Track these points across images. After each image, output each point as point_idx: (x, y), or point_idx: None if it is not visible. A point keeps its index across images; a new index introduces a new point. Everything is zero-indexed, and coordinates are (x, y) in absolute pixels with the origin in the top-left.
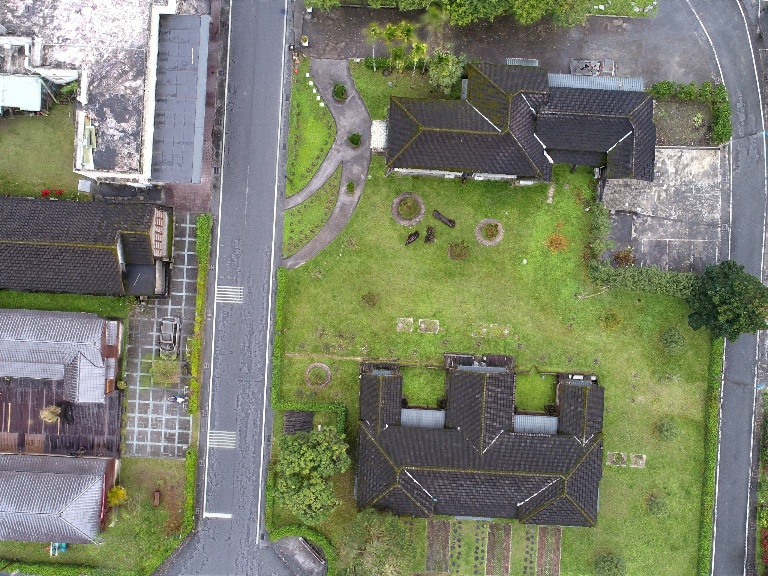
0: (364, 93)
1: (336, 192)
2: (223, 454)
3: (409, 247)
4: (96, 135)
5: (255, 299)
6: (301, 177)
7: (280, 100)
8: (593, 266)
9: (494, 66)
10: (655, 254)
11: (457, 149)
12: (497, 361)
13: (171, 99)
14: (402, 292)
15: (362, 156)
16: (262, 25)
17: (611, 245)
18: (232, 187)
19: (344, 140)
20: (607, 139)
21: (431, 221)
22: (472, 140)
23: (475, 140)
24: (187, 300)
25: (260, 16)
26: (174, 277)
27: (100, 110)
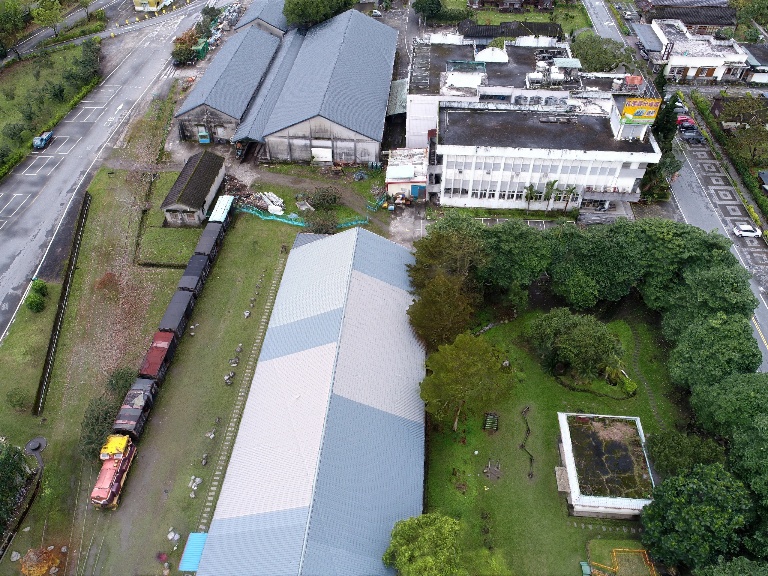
0: None
1: None
2: (597, 1)
3: None
4: None
5: None
6: None
7: None
8: None
9: None
10: None
11: None
12: (505, 9)
13: None
14: None
15: None
16: None
17: None
18: None
19: None
20: None
21: None
22: None
23: None
24: None
25: None
26: None
27: (679, 33)
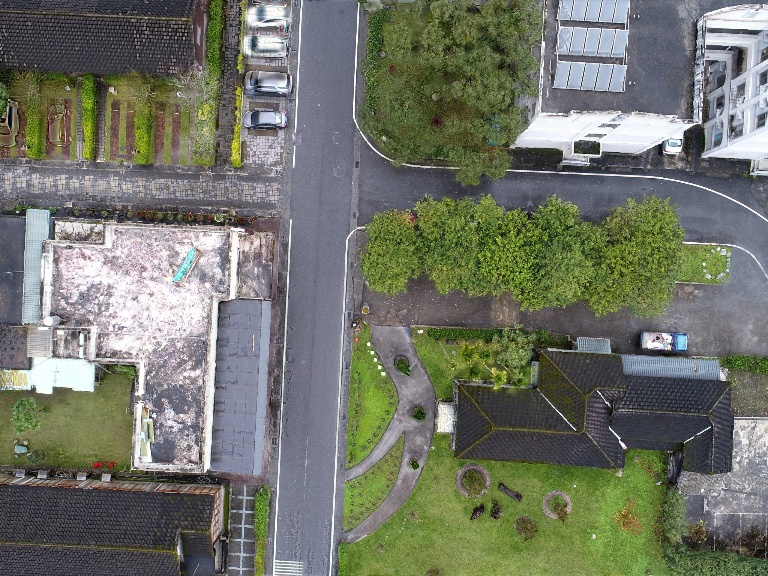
0: (427, 361)
1: (398, 463)
2: None
3: (474, 520)
4: (154, 426)
5: (315, 574)
6: (362, 448)
7: (340, 368)
8: (668, 555)
9: (567, 355)
10: (728, 528)
11: (530, 445)
12: None
13: (231, 387)
14: (467, 567)
15: (425, 426)
16: (321, 291)
17: (686, 532)
18: (290, 458)
19: (406, 410)
20: (684, 432)
21: (496, 494)
22: (546, 438)
23: (549, 438)
24: (244, 575)
25: (319, 282)
26: (231, 551)
27: (158, 401)
